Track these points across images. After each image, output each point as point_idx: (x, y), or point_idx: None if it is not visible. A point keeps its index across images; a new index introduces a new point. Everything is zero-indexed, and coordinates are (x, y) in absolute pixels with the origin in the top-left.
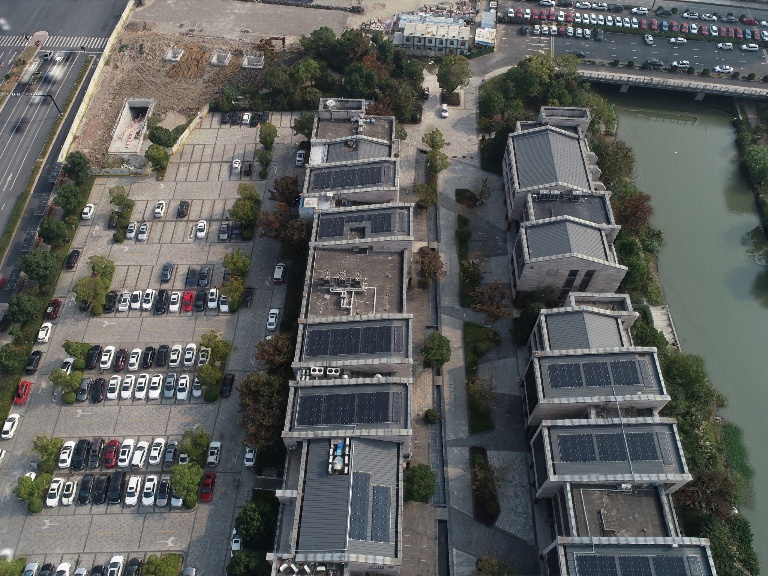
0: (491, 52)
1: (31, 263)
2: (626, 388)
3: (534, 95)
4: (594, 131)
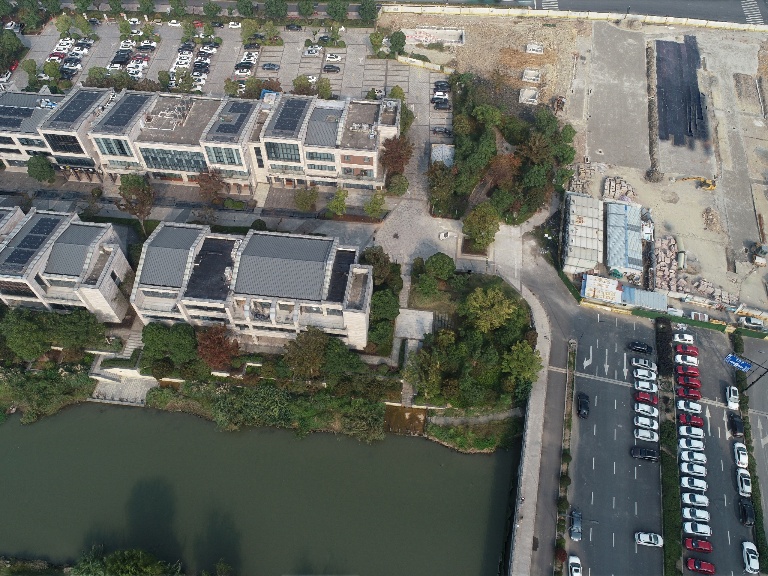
0: (578, 300)
1: None
2: (8, 254)
3: (458, 312)
4: (418, 395)
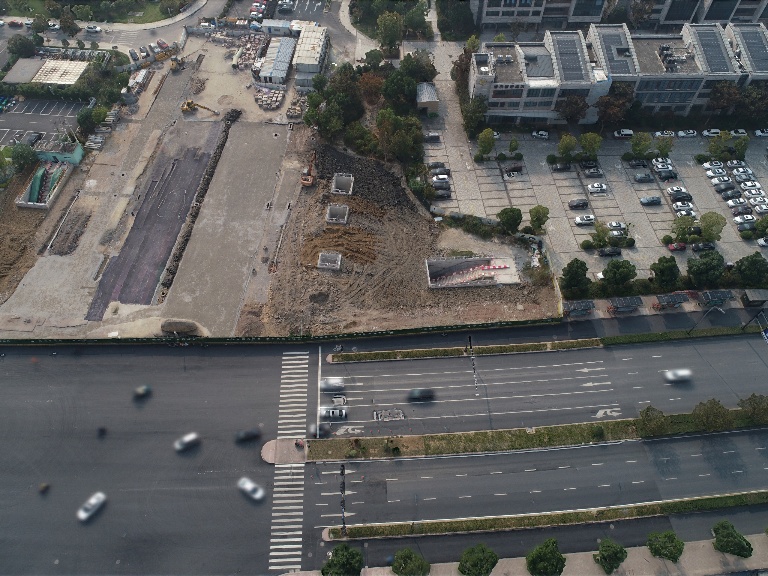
0: None
1: None
2: None
3: None
4: None
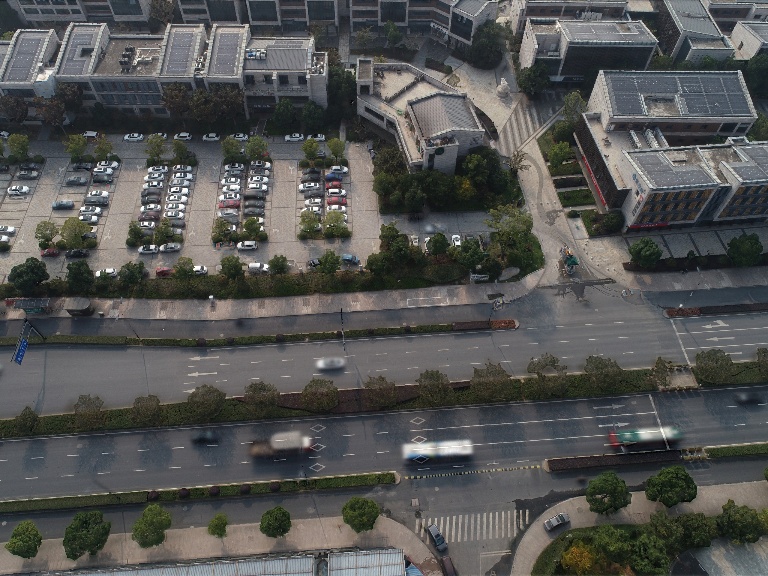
0: None
1: (32, 264)
2: None
3: None
4: None
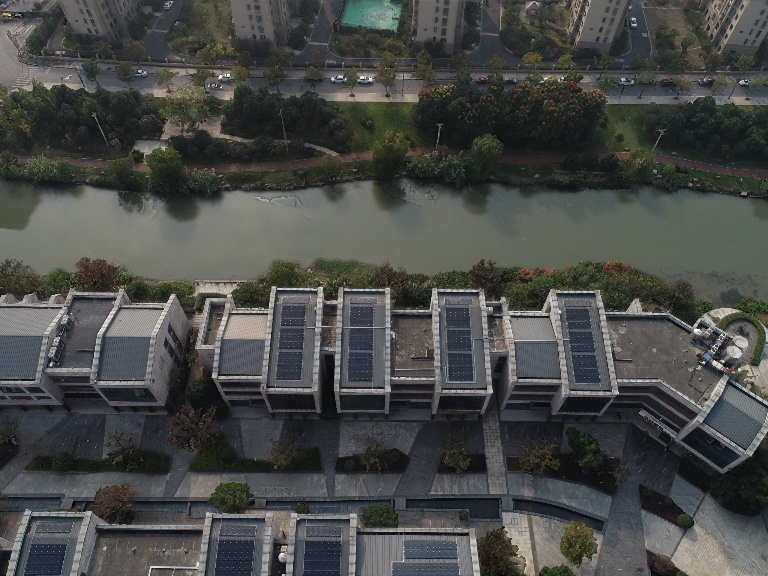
0: None
1: None
2: (308, 318)
3: None
4: None
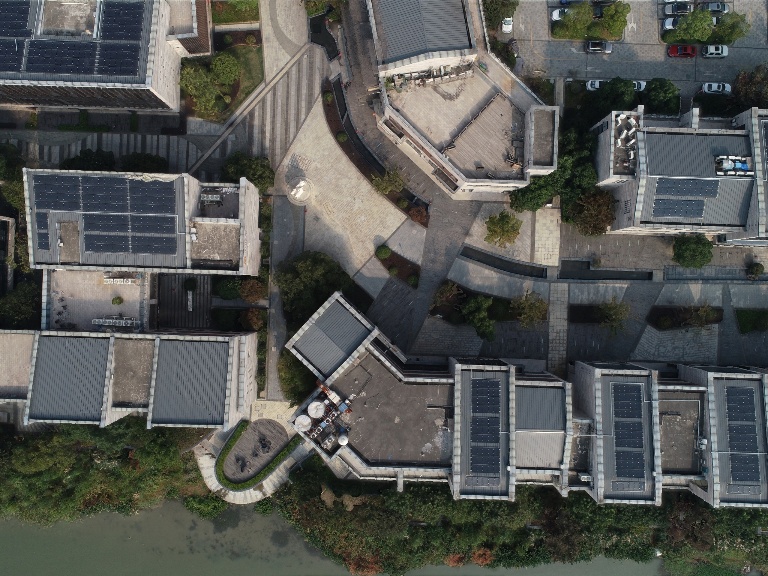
0: None
1: None
2: None
3: None
4: None
